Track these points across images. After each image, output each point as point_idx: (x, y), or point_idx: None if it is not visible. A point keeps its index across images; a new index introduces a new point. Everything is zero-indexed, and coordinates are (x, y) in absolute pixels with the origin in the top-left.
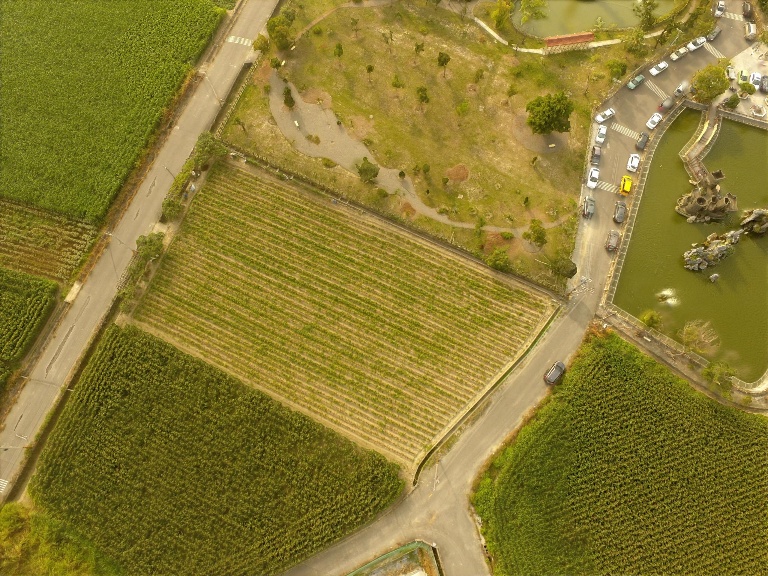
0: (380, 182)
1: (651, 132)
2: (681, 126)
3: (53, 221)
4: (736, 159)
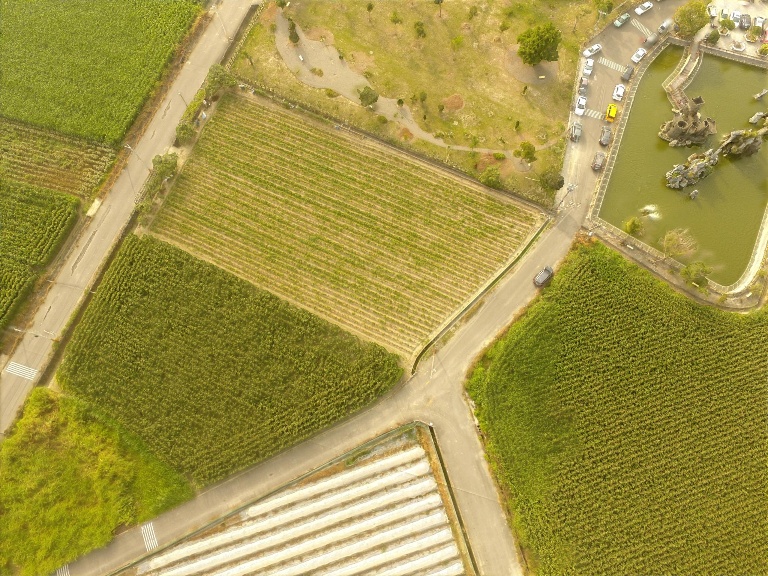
0: (380, 110)
1: (636, 65)
2: (665, 61)
3: (74, 145)
4: (716, 90)
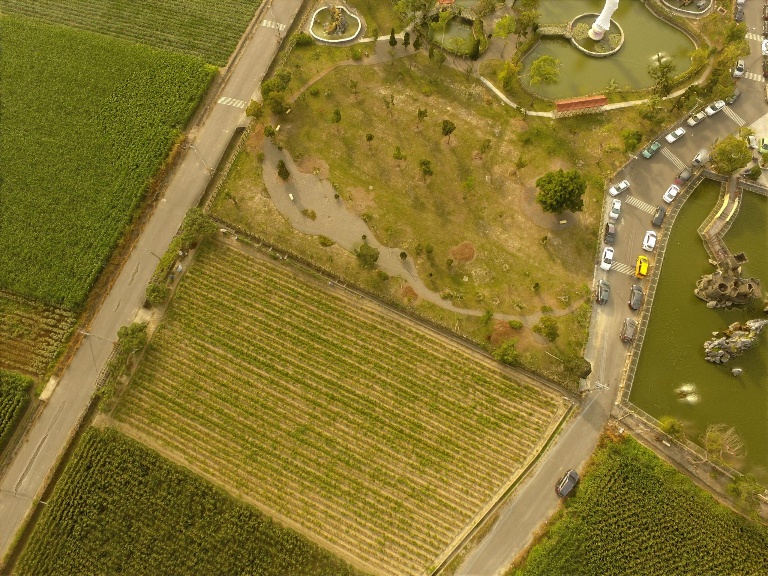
0: (380, 263)
1: (668, 206)
2: (699, 198)
3: (29, 306)
4: (758, 236)
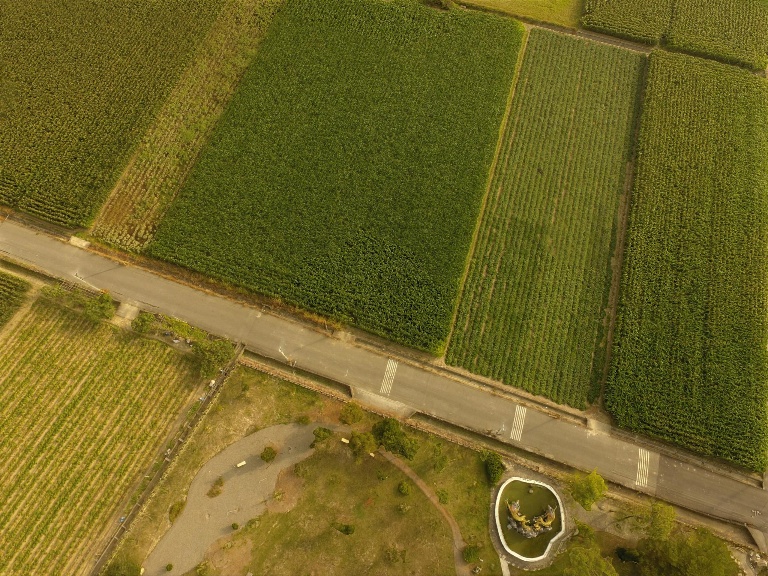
0: None
1: None
2: None
3: None
4: None
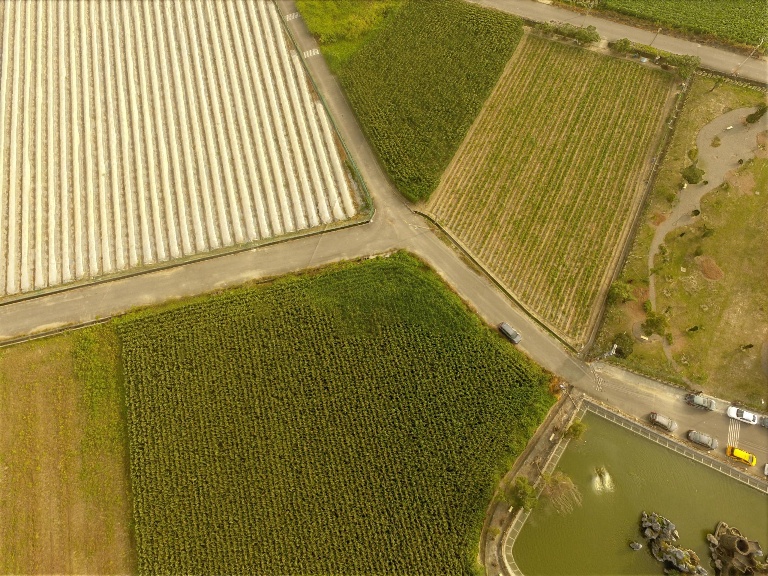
0: (683, 196)
1: None
2: None
3: None
4: None
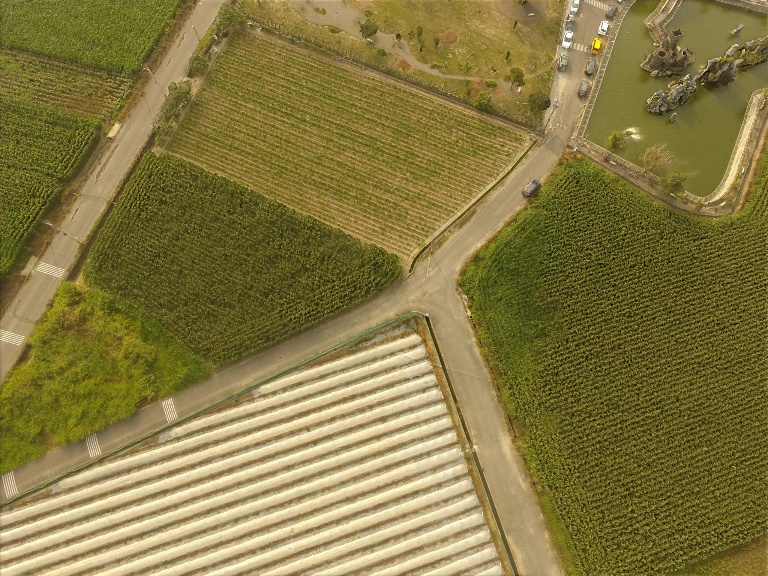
0: (379, 44)
1: (620, 4)
2: (647, 1)
3: (95, 77)
4: (696, 27)
